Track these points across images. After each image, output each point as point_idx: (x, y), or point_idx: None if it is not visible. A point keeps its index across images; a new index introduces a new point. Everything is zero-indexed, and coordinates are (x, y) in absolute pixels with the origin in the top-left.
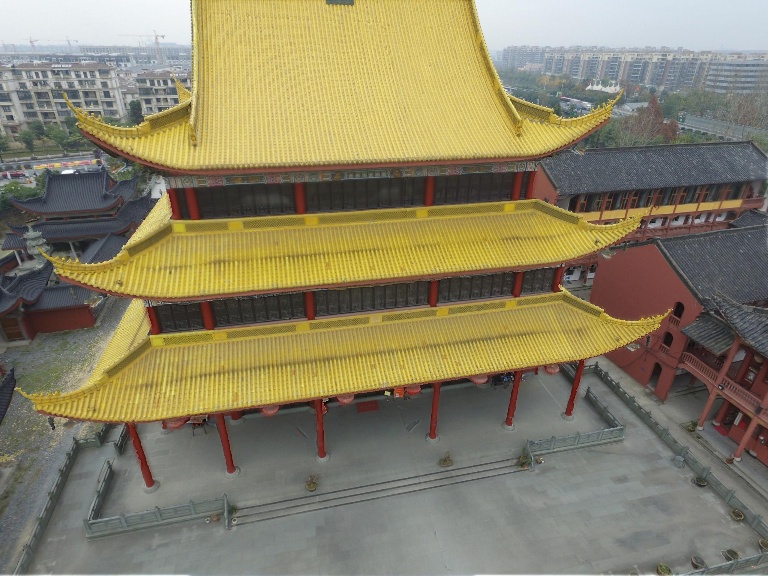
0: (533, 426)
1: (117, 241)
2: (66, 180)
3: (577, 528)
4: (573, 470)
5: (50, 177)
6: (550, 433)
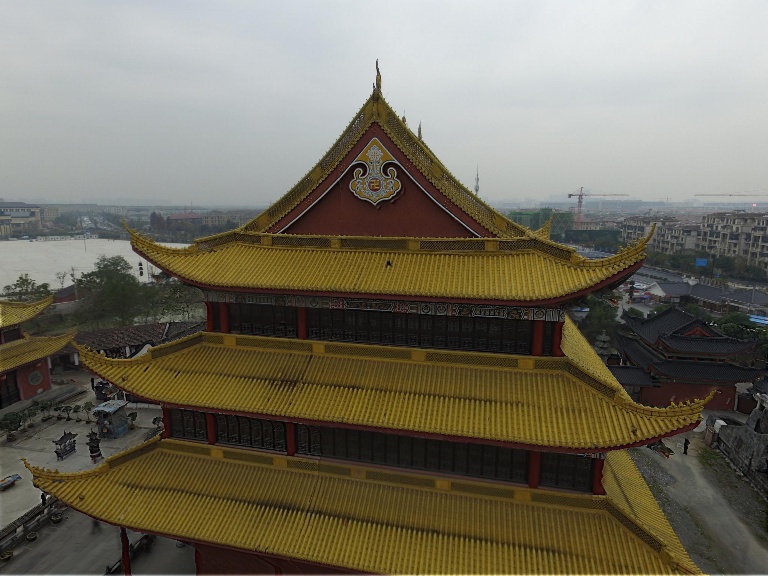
0: (161, 562)
1: (632, 374)
2: (677, 315)
3: (85, 536)
4: (103, 570)
5: (672, 309)
6: (141, 570)
